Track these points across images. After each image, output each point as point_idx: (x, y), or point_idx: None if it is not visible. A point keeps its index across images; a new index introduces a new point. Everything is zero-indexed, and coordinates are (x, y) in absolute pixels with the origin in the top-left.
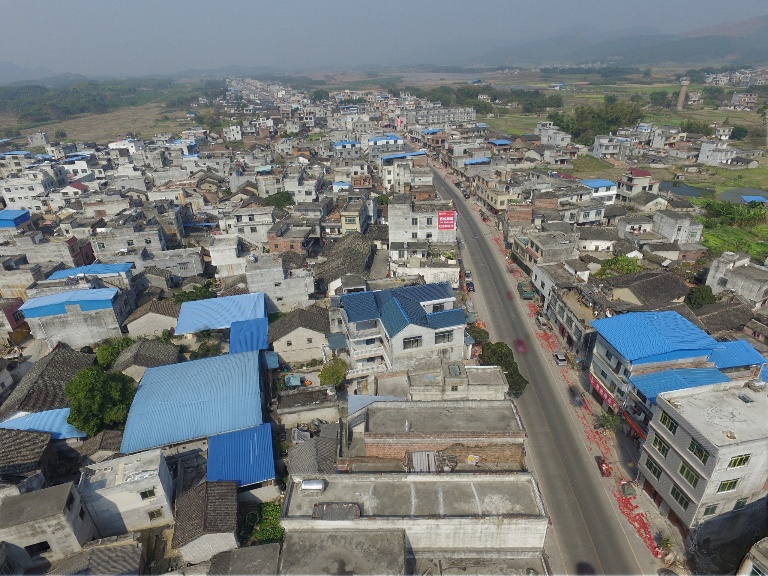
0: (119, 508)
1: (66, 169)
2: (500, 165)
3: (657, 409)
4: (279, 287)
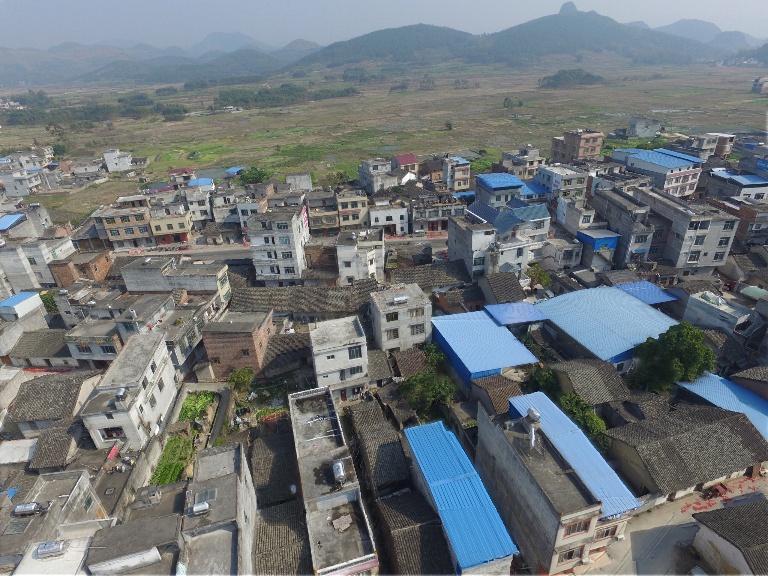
0: None
1: None
2: (42, 215)
3: (562, 182)
4: None
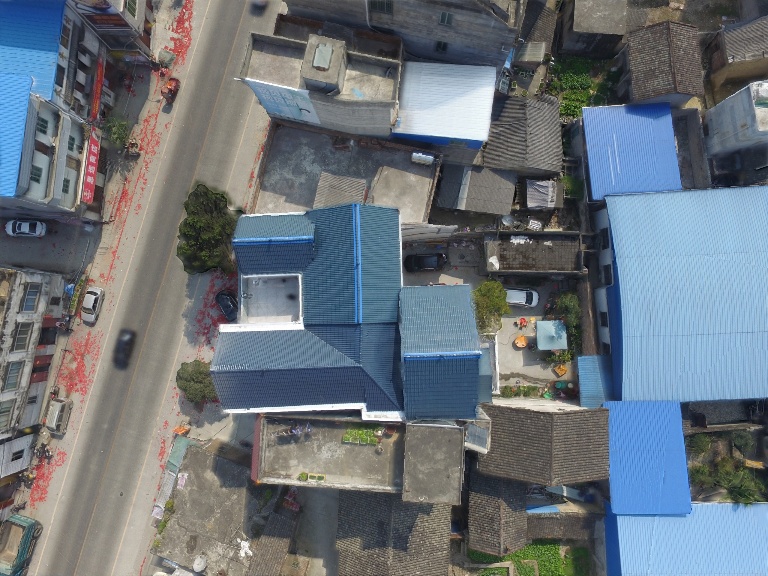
0: None
1: None
2: None
3: None
4: None
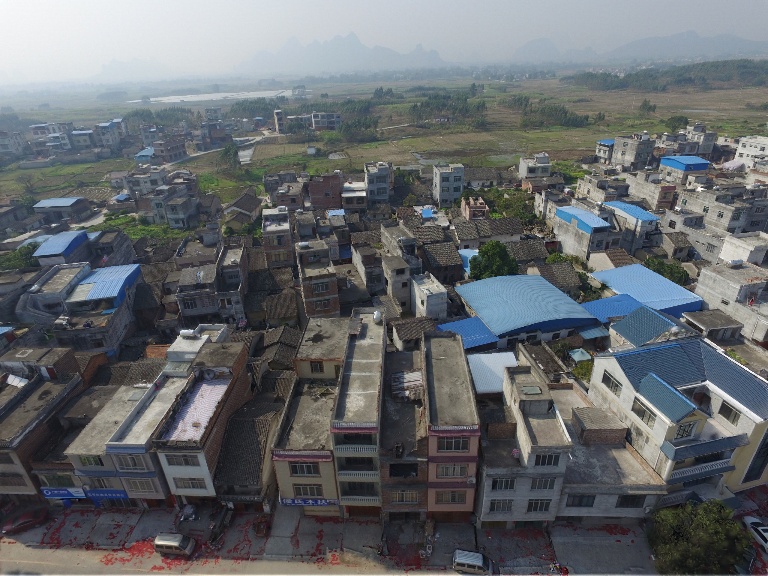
0: (416, 300)
1: None
2: None
3: None
4: (725, 306)
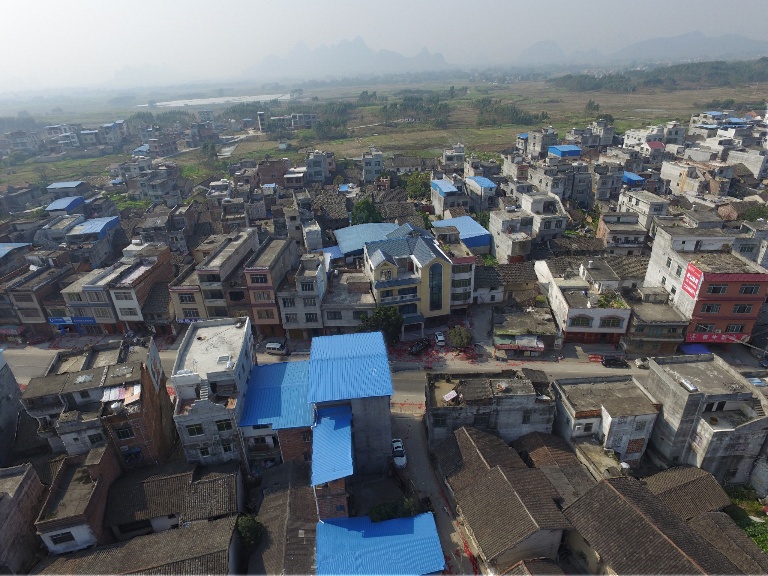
0: None
1: (720, 134)
2: None
3: None
4: None
